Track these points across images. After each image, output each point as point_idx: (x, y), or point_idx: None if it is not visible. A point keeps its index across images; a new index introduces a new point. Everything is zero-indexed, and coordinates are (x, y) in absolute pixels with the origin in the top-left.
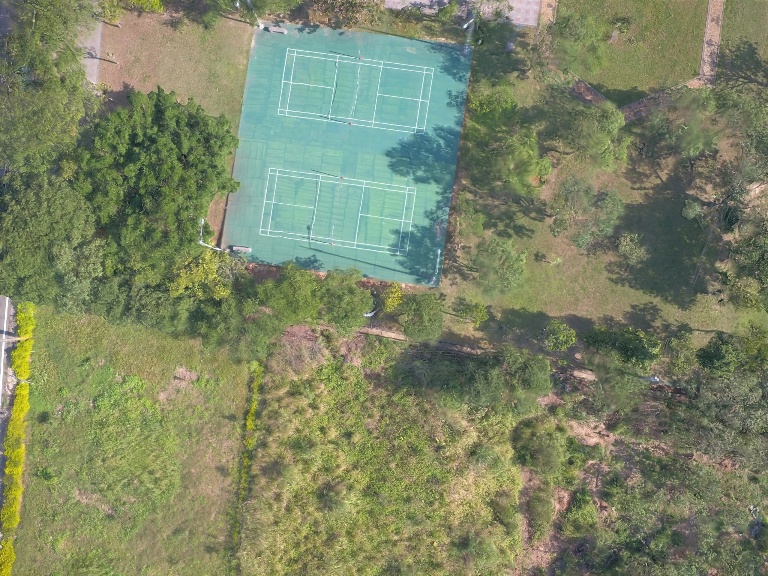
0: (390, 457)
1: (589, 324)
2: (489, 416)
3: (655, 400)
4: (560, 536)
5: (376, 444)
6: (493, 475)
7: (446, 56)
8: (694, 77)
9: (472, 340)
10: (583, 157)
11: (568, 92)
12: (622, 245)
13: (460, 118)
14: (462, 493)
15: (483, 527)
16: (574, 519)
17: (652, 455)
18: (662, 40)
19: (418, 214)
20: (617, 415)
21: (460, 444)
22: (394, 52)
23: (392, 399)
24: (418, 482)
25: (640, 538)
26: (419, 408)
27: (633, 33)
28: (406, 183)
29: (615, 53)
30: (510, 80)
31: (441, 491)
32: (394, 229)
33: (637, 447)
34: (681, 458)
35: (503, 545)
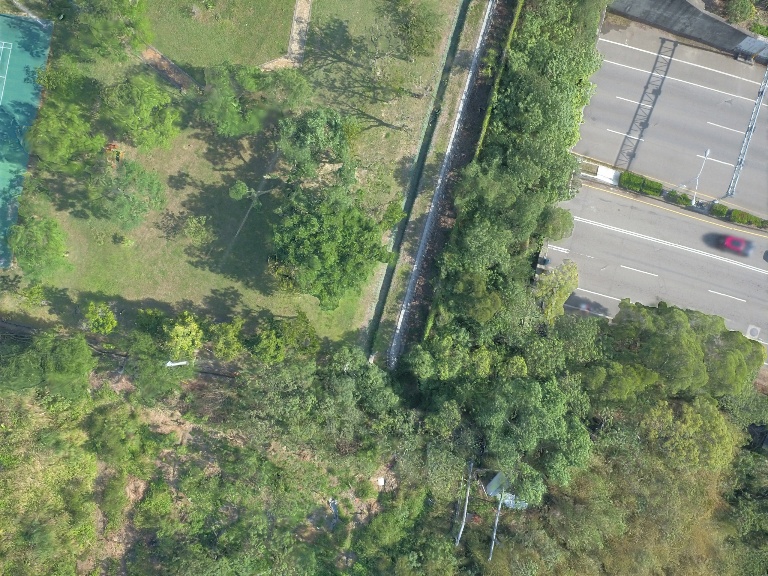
0: None
1: (167, 309)
2: (56, 402)
3: (227, 388)
4: (134, 527)
5: None
6: (48, 462)
7: (24, 31)
8: (281, 55)
9: (47, 323)
10: (164, 136)
11: (151, 69)
12: (189, 227)
13: (38, 95)
14: (29, 481)
15: (50, 516)
16: (147, 509)
17: (230, 444)
18: (249, 17)
19: None
20: (184, 402)
21: (28, 430)
22: None
23: None
24: None
25: (214, 530)
26: None
27: (220, 9)
28: None
29: (200, 30)
30: (91, 56)
31: (5, 478)
32: None
33: (215, 436)
34: (260, 448)
35: (69, 535)
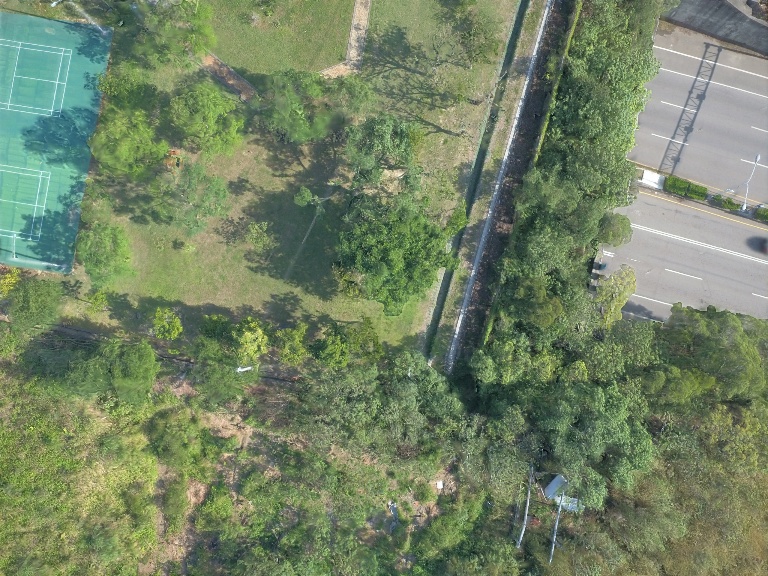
0: (20, 447)
1: (227, 314)
2: (118, 406)
3: (288, 392)
4: (195, 530)
5: (8, 434)
6: (112, 467)
7: (84, 37)
8: (340, 62)
9: (108, 329)
10: None
11: (210, 76)
12: (251, 233)
13: (98, 101)
14: (91, 485)
15: (112, 520)
16: (208, 513)
17: (290, 448)
18: (308, 24)
19: (51, 199)
20: (246, 407)
21: (90, 435)
22: (32, 33)
23: (23, 388)
24: (48, 473)
25: (274, 533)
26: (51, 397)
27: (278, 16)
28: (40, 167)
29: (259, 36)
30: (151, 63)
31: (68, 482)
32: (26, 214)
33: (275, 440)
34: (319, 452)
35: (131, 538)
